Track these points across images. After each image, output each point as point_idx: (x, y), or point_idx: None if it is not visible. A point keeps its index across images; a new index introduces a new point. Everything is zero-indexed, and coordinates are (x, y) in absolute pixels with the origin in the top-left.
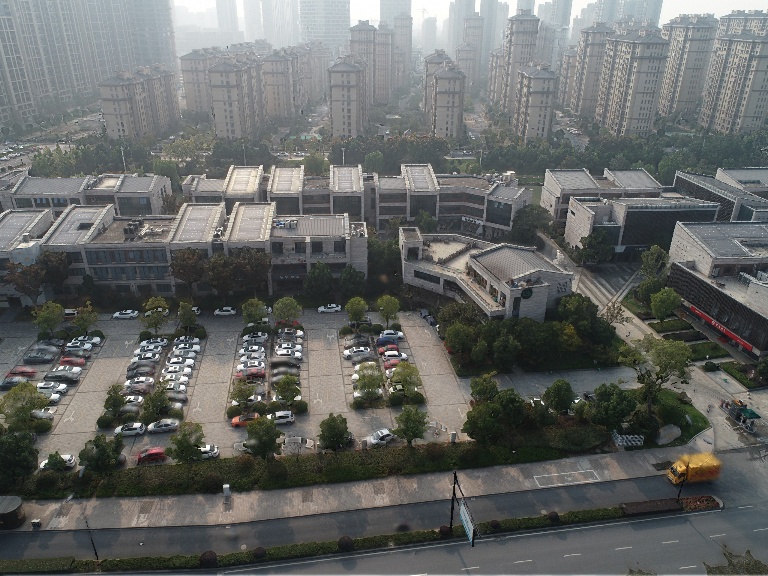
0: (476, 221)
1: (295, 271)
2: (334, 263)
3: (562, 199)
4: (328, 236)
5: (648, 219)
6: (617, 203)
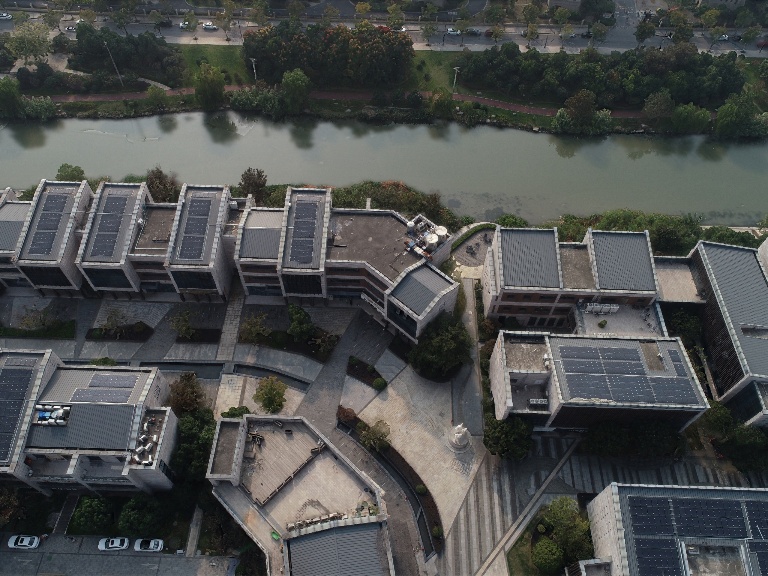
0: (377, 309)
1: (70, 484)
2: (118, 484)
3: (502, 297)
4: (104, 454)
5: (593, 412)
6: (554, 382)
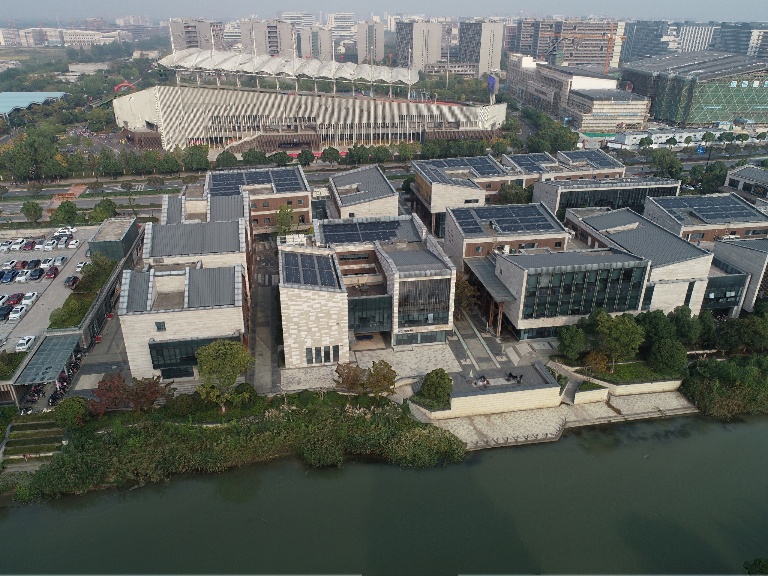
0: None
1: None
2: None
3: None
4: None
5: None
6: None
